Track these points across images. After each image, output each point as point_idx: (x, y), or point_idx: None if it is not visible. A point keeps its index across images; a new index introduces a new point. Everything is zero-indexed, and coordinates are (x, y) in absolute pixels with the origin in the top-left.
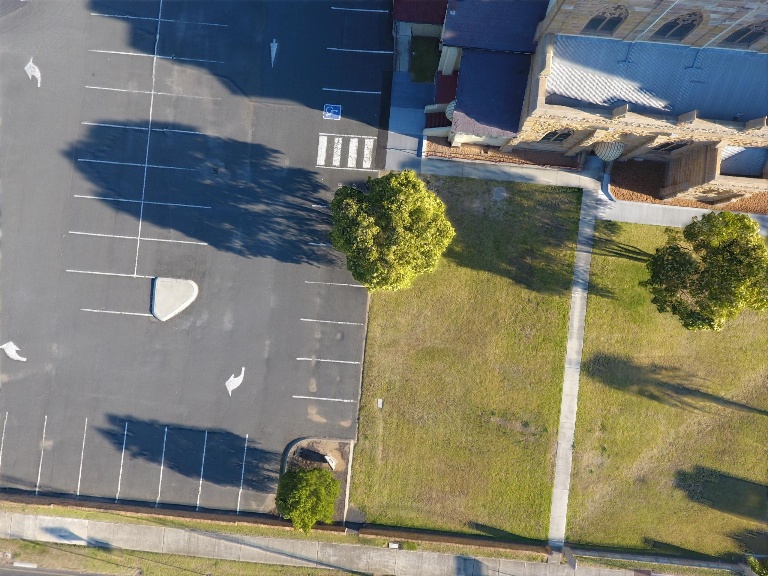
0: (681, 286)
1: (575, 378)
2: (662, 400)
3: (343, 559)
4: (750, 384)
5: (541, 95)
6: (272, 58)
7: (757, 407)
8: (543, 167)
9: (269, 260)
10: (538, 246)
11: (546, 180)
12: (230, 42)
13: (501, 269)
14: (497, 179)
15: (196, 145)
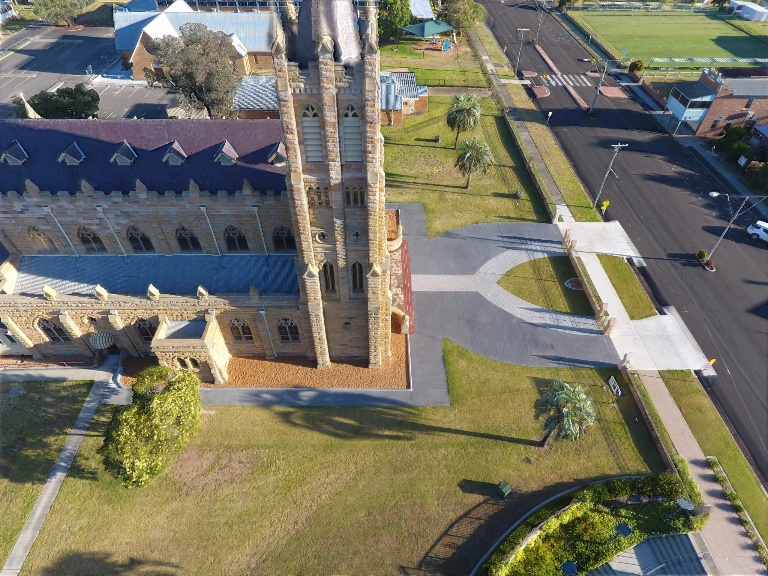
0: None
1: None
2: None
3: None
4: (232, 567)
5: None
6: None
7: None
8: (65, 367)
9: None
10: (32, 434)
11: (64, 377)
12: None
13: None
14: (20, 380)
15: None
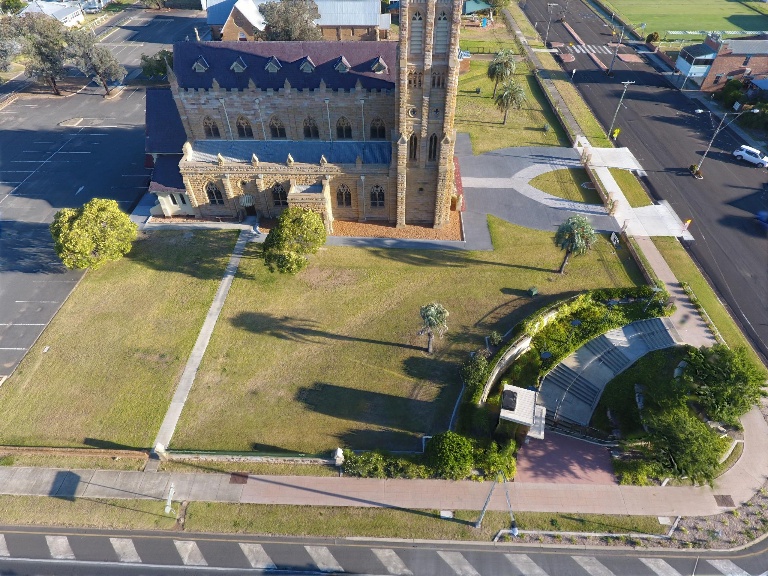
0: (273, 246)
1: (212, 324)
2: (280, 336)
3: None
4: (351, 323)
5: None
6: (77, 192)
7: (356, 337)
8: (219, 222)
9: (15, 272)
10: (206, 256)
11: (219, 227)
12: (57, 188)
13: (177, 269)
14: (189, 229)
15: (6, 225)
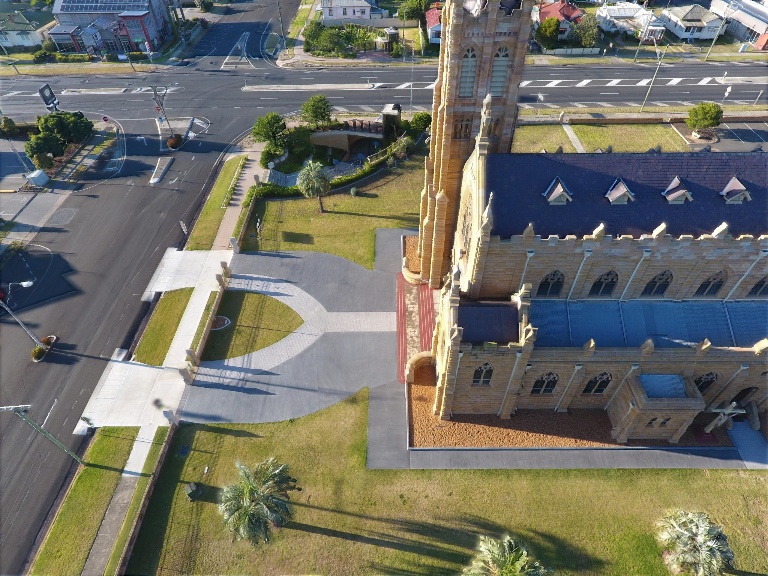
0: None
1: None
2: None
3: (662, 115)
4: None
5: None
6: None
7: None
8: None
9: None
10: None
11: None
12: None
13: None
14: None
15: None
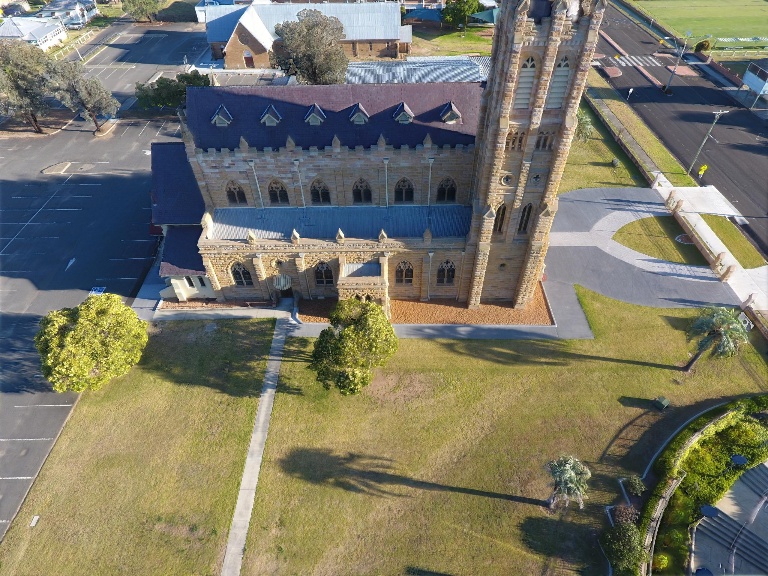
0: (328, 355)
1: (255, 470)
2: (347, 486)
3: None
4: (438, 461)
5: (203, 235)
6: (68, 267)
7: (448, 484)
8: (247, 307)
9: None
10: (236, 360)
11: (249, 315)
12: (42, 261)
13: (201, 380)
14: (211, 318)
15: None
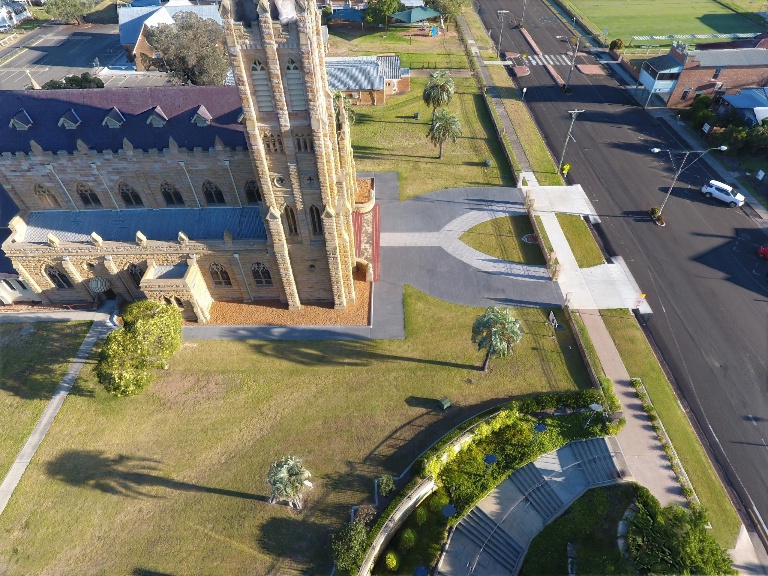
0: None
1: (19, 472)
2: (106, 488)
3: None
4: (205, 462)
5: (9, 239)
6: None
7: (207, 485)
8: (69, 310)
9: None
10: (41, 362)
11: (68, 318)
12: None
13: None
14: (30, 321)
15: None
